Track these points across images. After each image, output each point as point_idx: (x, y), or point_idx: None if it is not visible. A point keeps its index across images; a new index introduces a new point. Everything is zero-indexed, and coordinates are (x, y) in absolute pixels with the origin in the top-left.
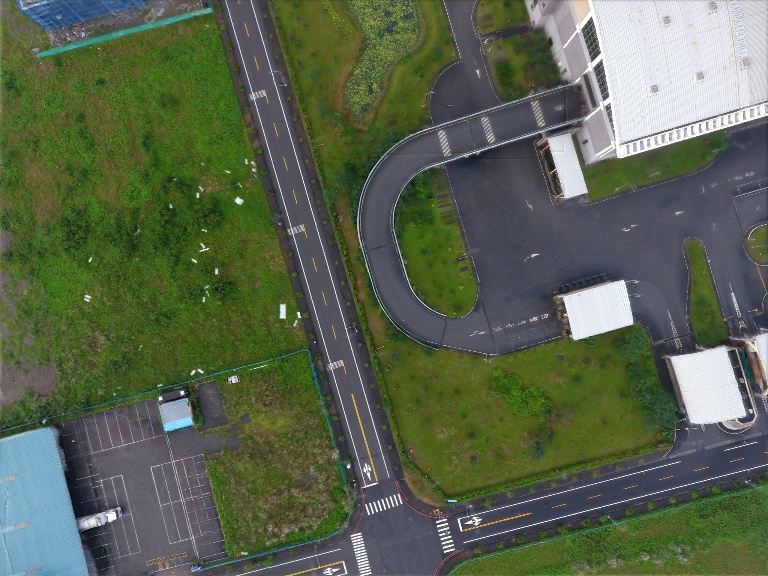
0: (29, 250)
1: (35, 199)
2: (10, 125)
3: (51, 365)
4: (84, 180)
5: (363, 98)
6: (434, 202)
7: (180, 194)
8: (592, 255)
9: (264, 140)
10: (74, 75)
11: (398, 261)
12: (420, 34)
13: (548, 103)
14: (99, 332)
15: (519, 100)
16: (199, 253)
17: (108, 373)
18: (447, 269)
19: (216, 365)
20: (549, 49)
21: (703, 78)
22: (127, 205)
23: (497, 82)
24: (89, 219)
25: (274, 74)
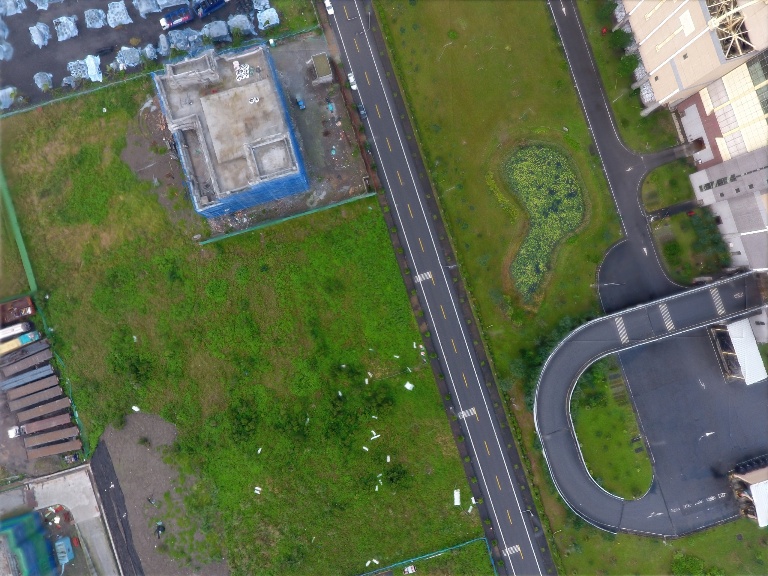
0: (197, 443)
1: (201, 390)
2: (174, 315)
3: (223, 561)
4: (251, 369)
5: (530, 278)
6: (607, 383)
7: (349, 381)
8: (766, 432)
9: (431, 323)
10: (237, 262)
11: (574, 445)
12: (586, 213)
13: (728, 290)
14: (273, 527)
15: (699, 288)
16: (371, 441)
17: (282, 567)
18: (622, 451)
19: (392, 555)
20: (716, 226)
21: None
22: (296, 394)
23: (665, 260)
24: (258, 409)
25: (439, 255)
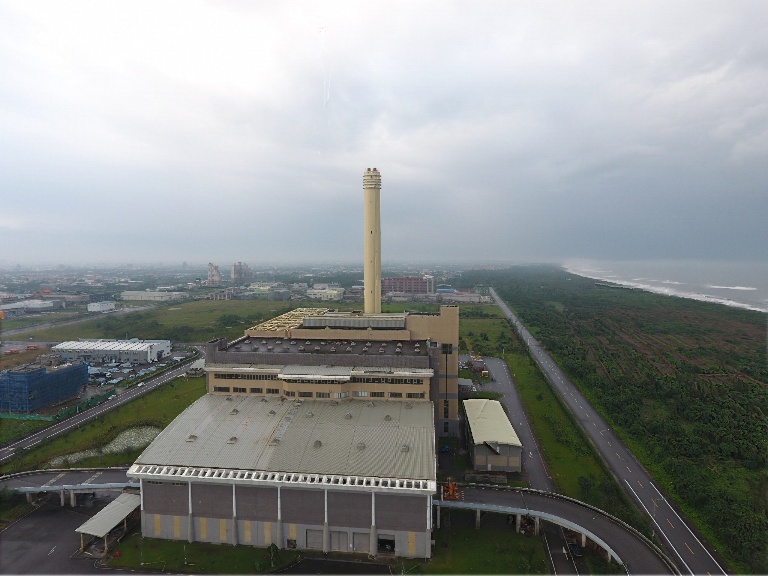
0: None
1: None
2: None
3: None
4: None
5: None
6: None
7: None
8: None
9: None
10: None
11: None
12: None
13: None
14: None
15: None
16: None
17: None
18: None
19: None
20: None
21: (233, 440)
22: None
23: None
24: None
25: None
